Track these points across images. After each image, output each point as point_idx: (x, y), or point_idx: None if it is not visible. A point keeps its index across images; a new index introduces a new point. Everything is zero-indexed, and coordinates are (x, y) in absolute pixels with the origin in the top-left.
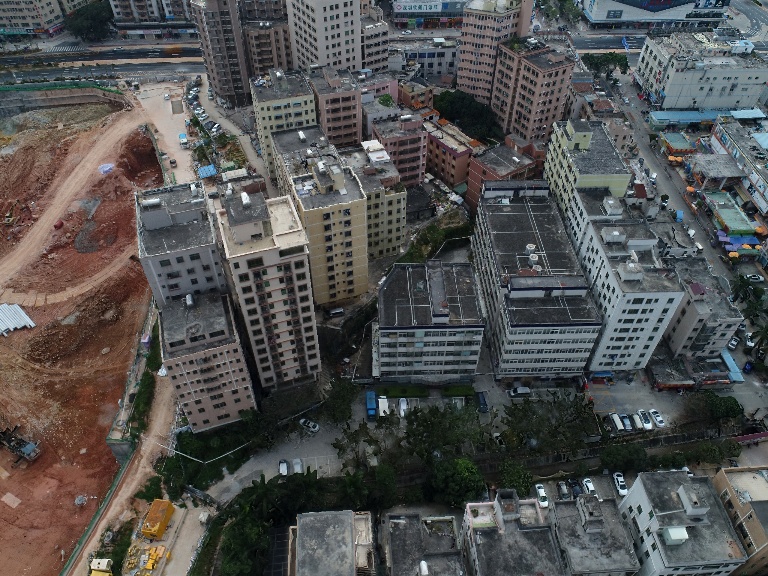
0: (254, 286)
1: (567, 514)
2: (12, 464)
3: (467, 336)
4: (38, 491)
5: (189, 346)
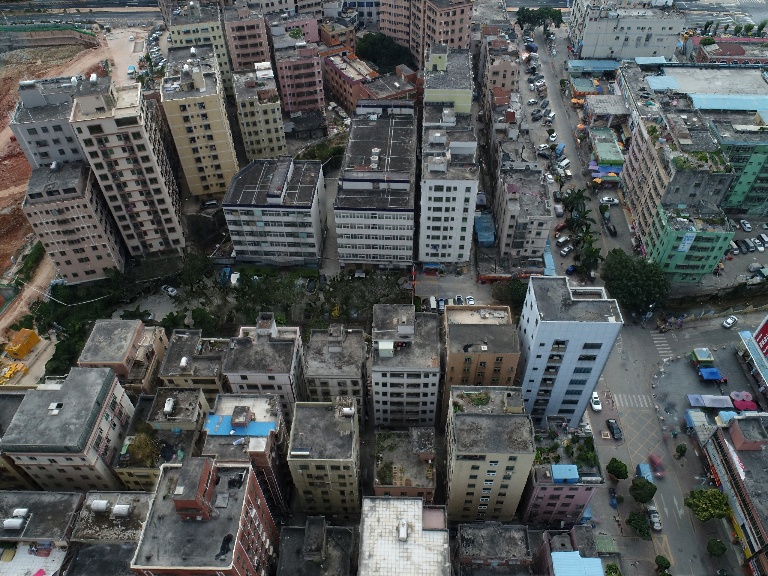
0: (100, 152)
1: (320, 339)
2: None
3: (299, 217)
4: None
5: (47, 200)
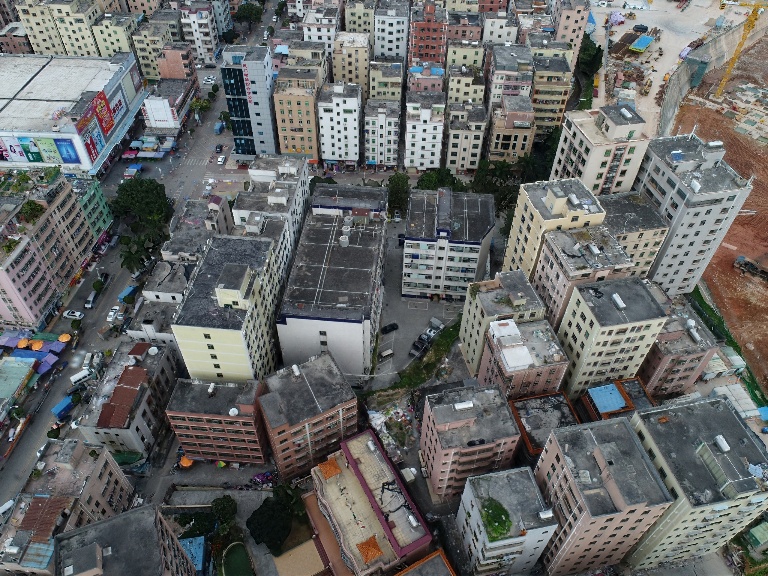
0: None
1: None
2: None
3: None
4: None
5: None
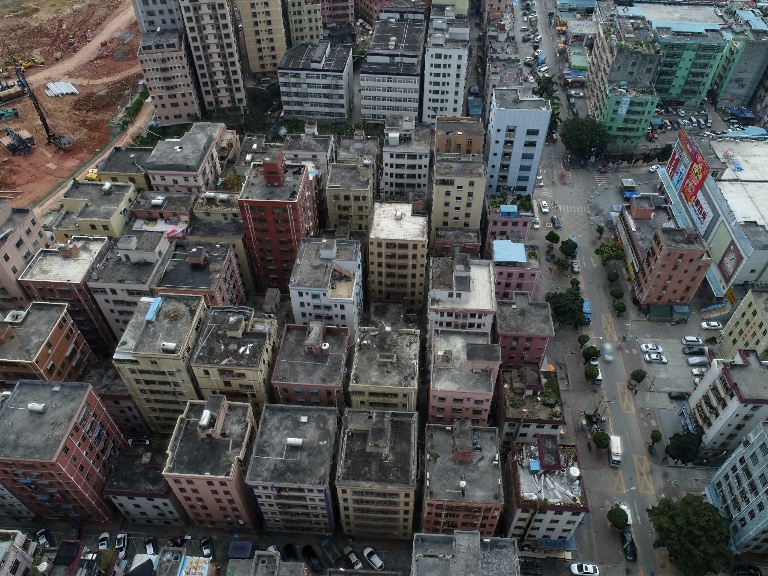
0: (194, 18)
1: (348, 142)
2: (55, 150)
3: (334, 80)
4: (68, 164)
5: (154, 52)
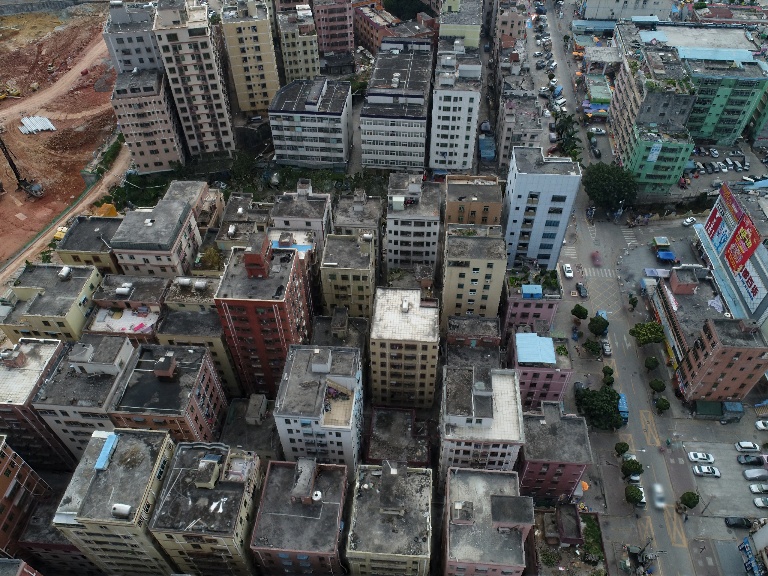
0: (174, 58)
1: (346, 202)
2: (25, 198)
3: (331, 123)
4: (39, 214)
5: (130, 96)
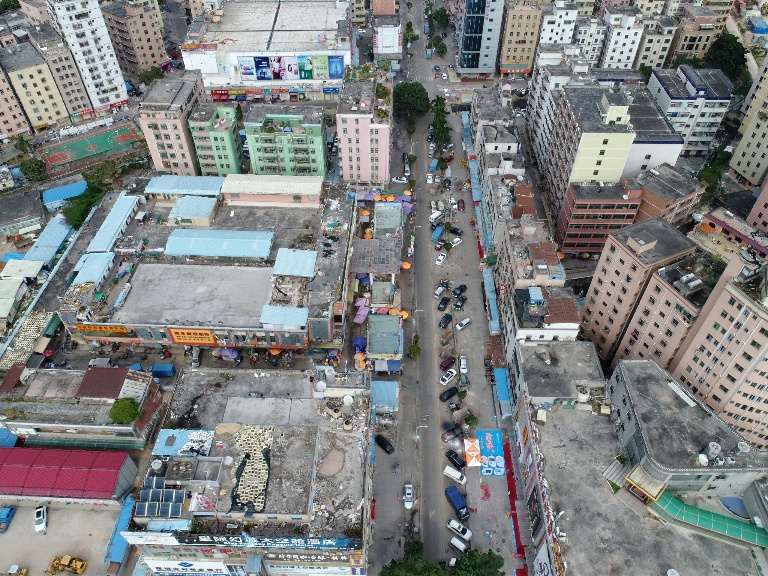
0: None
1: None
2: None
3: None
4: None
5: None
